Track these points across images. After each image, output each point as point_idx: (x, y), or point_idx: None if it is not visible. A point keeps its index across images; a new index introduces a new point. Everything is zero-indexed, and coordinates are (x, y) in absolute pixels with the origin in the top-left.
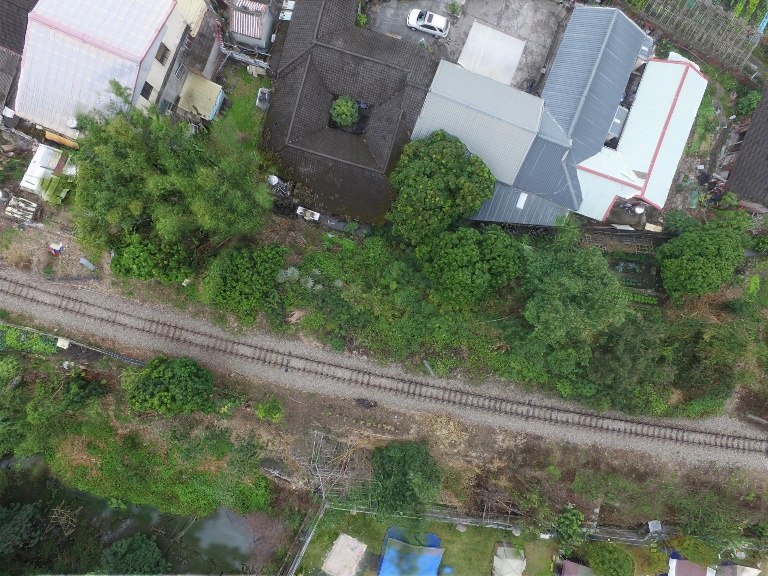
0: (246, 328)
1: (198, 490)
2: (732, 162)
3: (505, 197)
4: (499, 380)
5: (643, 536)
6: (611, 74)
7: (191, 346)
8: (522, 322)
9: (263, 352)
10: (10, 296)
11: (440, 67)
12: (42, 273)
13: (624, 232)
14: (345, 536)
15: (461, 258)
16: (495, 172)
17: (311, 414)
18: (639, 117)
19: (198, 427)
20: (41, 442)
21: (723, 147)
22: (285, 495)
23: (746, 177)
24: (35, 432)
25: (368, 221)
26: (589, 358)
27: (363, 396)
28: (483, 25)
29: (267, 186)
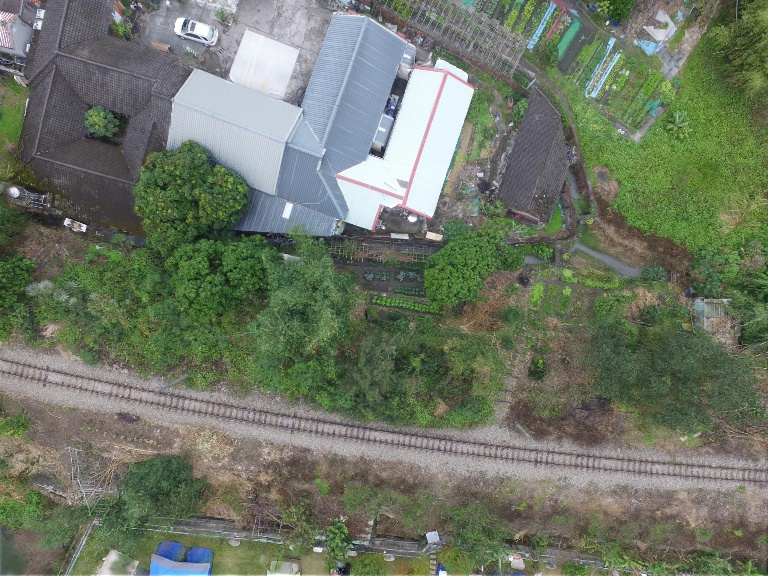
0: (2, 343)
1: None
2: None
3: (270, 207)
4: (265, 392)
5: (422, 548)
6: (368, 82)
7: None
8: None
9: (20, 367)
10: None
11: (191, 76)
12: None
13: (404, 241)
14: (116, 552)
15: (188, 271)
16: (255, 182)
17: (71, 429)
18: (404, 125)
19: None
20: None
21: (502, 154)
22: (58, 511)
23: (513, 185)
24: None
25: None
26: None
27: (124, 410)
28: (255, 33)
29: (9, 199)
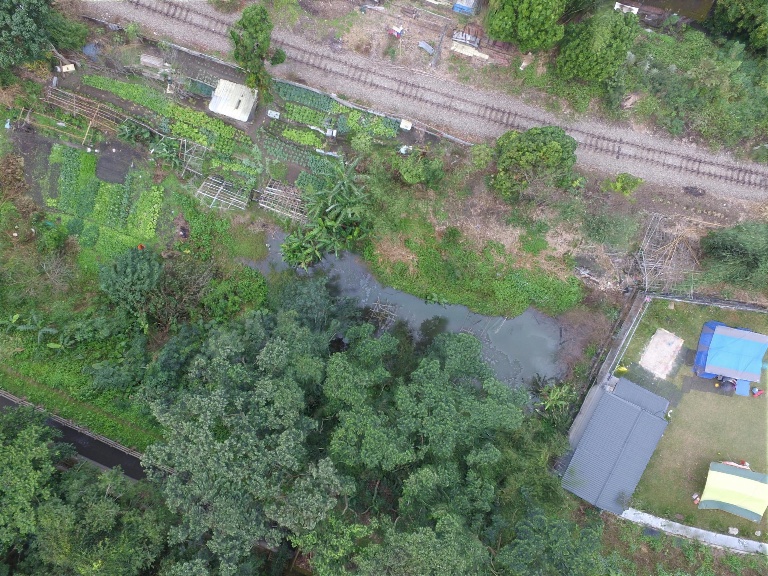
0: (578, 115)
1: (516, 285)
2: None
3: None
4: None
5: None
6: None
7: None
8: None
9: (594, 139)
10: (350, 80)
11: None
12: (381, 58)
13: None
14: (662, 331)
15: None
16: None
17: (640, 202)
18: None
19: (514, 224)
20: None
21: None
22: (597, 294)
23: None
24: (402, 197)
25: (686, 16)
26: None
27: (692, 184)
28: None
29: None
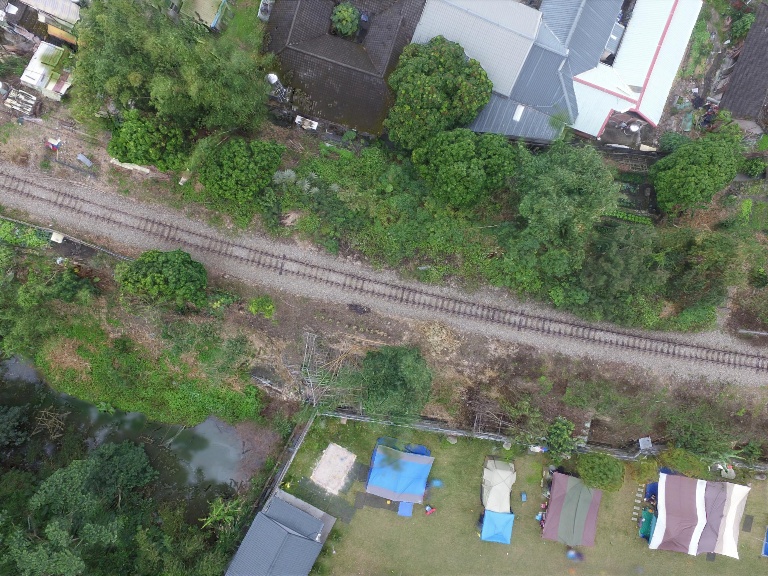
0: (241, 230)
1: (188, 396)
2: (726, 84)
3: (502, 109)
4: (492, 289)
5: (633, 453)
6: None
7: (186, 246)
8: (516, 223)
9: (258, 254)
10: (6, 190)
11: None
12: (39, 168)
13: (619, 152)
14: (335, 446)
15: (457, 152)
16: (492, 82)
17: (304, 318)
18: (635, 34)
19: None
20: (32, 331)
21: (717, 71)
22: (276, 404)
23: (739, 96)
24: (26, 318)
25: (366, 132)
26: (582, 264)
27: (356, 301)
28: None
29: (266, 84)
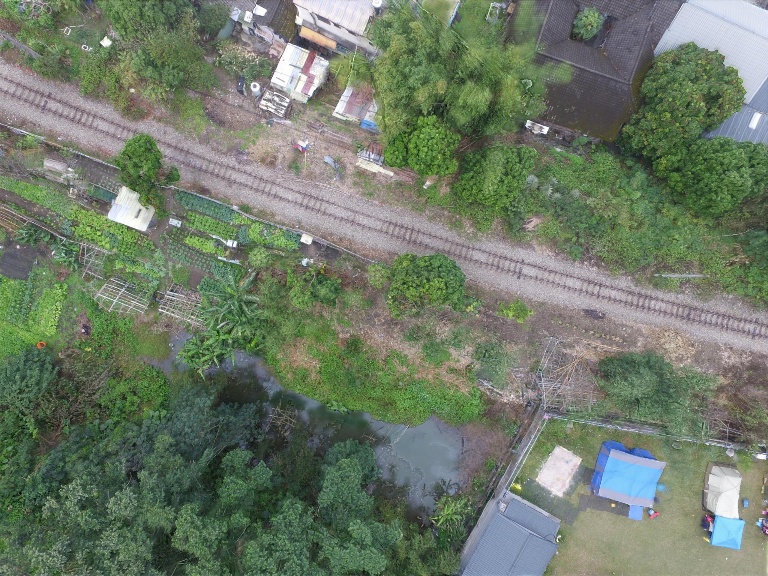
0: (481, 234)
1: (416, 396)
2: None
3: (738, 117)
4: (726, 297)
5: None
6: None
7: (427, 249)
8: None
9: (496, 259)
10: (254, 191)
11: None
12: (286, 170)
13: None
14: (560, 449)
15: (728, 161)
16: None
17: (540, 323)
18: None
19: (418, 334)
20: None
21: None
22: (499, 407)
23: None
24: (292, 319)
25: None
26: None
27: (592, 307)
28: None
29: (521, 90)
